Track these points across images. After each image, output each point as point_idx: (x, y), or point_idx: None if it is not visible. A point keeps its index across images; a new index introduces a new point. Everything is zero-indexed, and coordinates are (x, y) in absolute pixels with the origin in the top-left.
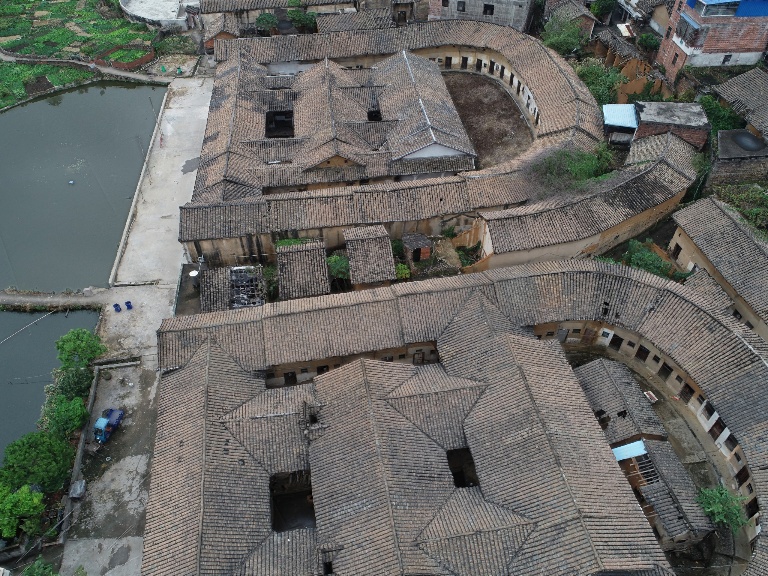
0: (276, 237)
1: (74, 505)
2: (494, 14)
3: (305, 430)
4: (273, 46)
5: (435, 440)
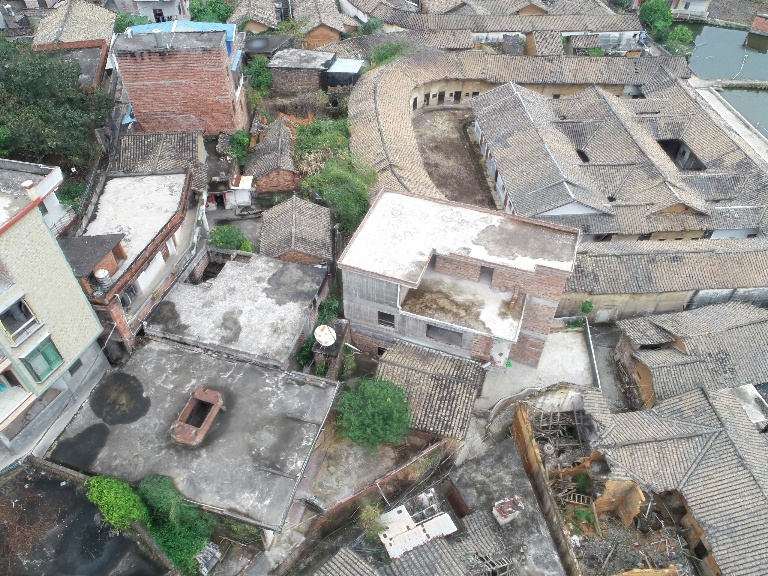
0: None
1: None
2: None
3: None
4: None
5: None
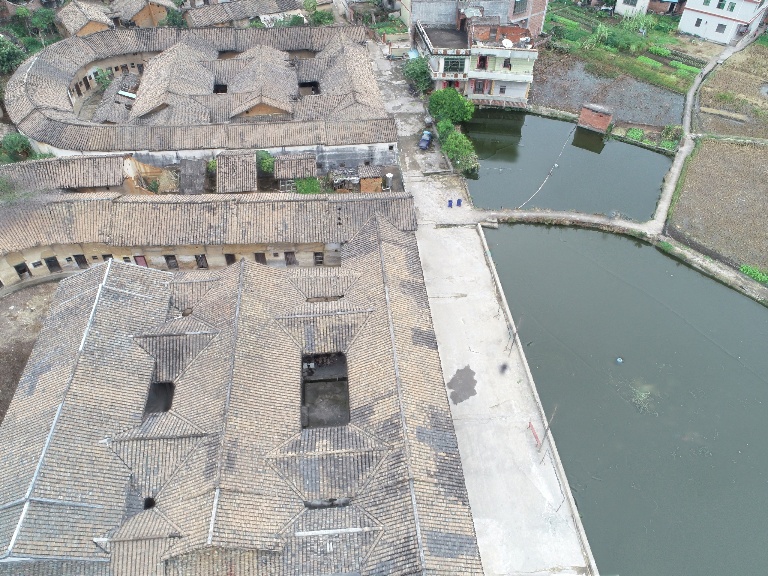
0: None
1: None
2: None
3: None
4: None
5: None
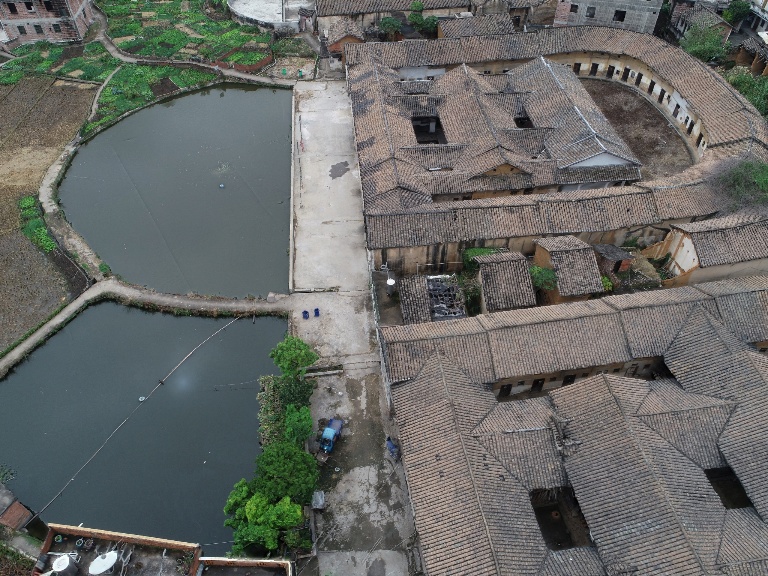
0: (462, 246)
1: (316, 516)
2: (625, 20)
3: (561, 446)
4: (404, 50)
5: (692, 459)
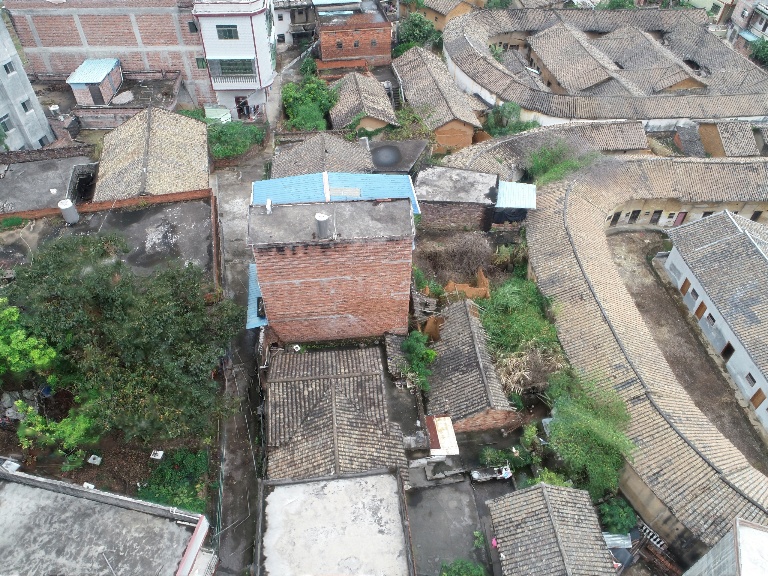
0: None
1: None
2: None
3: None
4: None
5: None
